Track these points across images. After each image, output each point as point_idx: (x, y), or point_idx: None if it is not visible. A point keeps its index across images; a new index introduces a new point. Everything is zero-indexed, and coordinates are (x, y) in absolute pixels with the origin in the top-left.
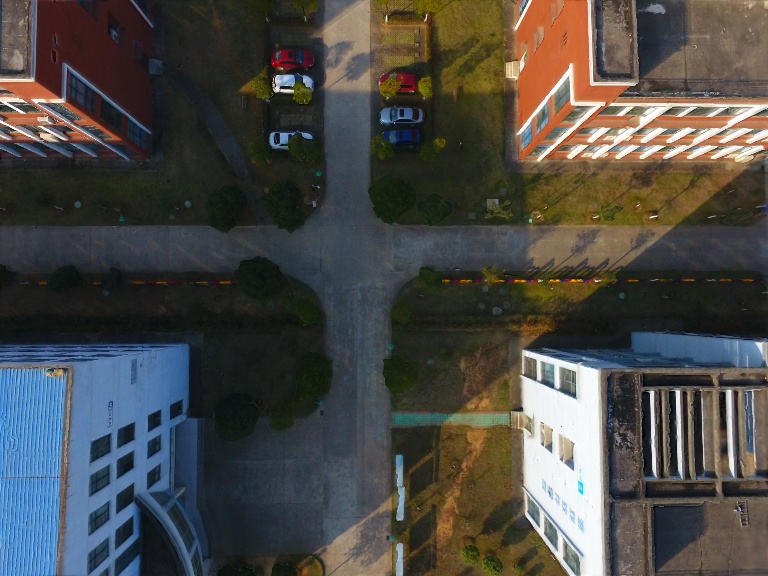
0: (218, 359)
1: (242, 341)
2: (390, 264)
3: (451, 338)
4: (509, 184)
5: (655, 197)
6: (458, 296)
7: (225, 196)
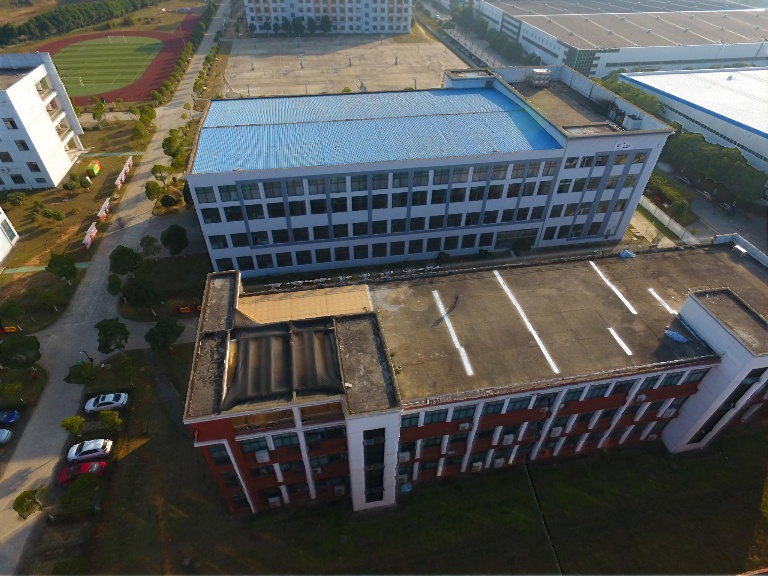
0: (199, 277)
1: (181, 286)
2: (53, 338)
3: (24, 302)
4: None
5: None
6: (5, 325)
7: (155, 329)
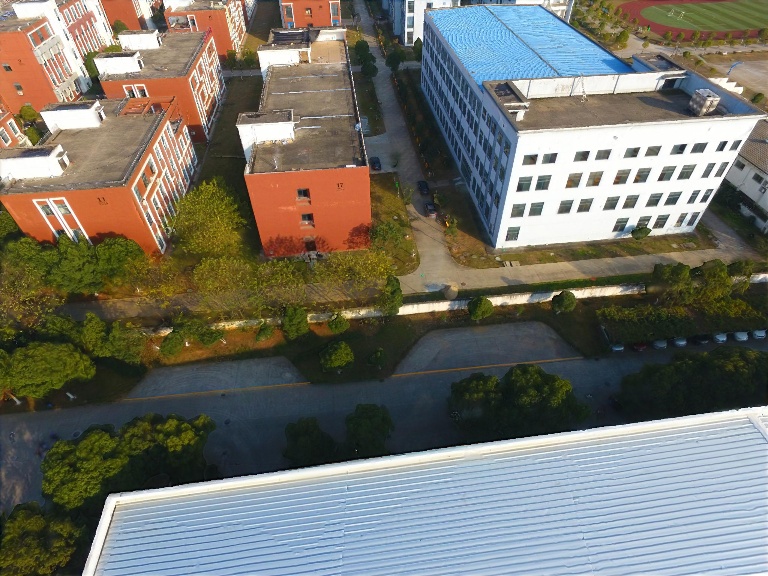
0: None
1: None
2: None
3: None
4: (351, 50)
5: (352, 35)
6: None
7: None
